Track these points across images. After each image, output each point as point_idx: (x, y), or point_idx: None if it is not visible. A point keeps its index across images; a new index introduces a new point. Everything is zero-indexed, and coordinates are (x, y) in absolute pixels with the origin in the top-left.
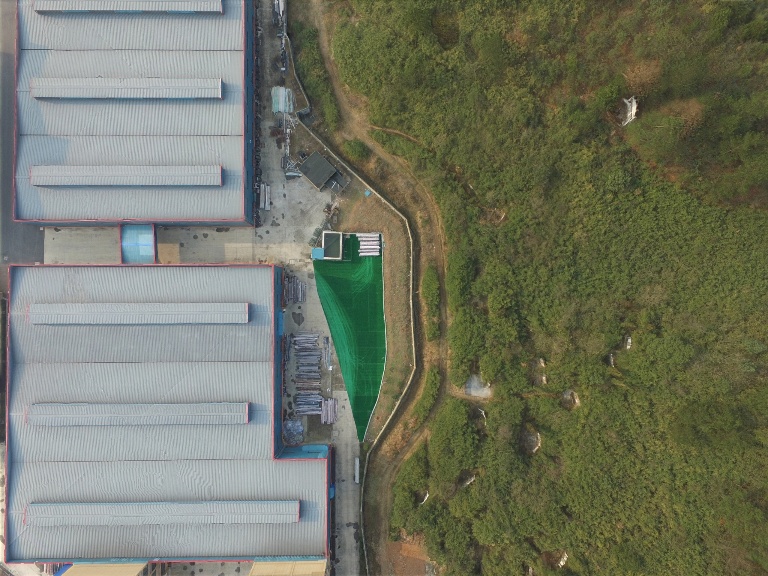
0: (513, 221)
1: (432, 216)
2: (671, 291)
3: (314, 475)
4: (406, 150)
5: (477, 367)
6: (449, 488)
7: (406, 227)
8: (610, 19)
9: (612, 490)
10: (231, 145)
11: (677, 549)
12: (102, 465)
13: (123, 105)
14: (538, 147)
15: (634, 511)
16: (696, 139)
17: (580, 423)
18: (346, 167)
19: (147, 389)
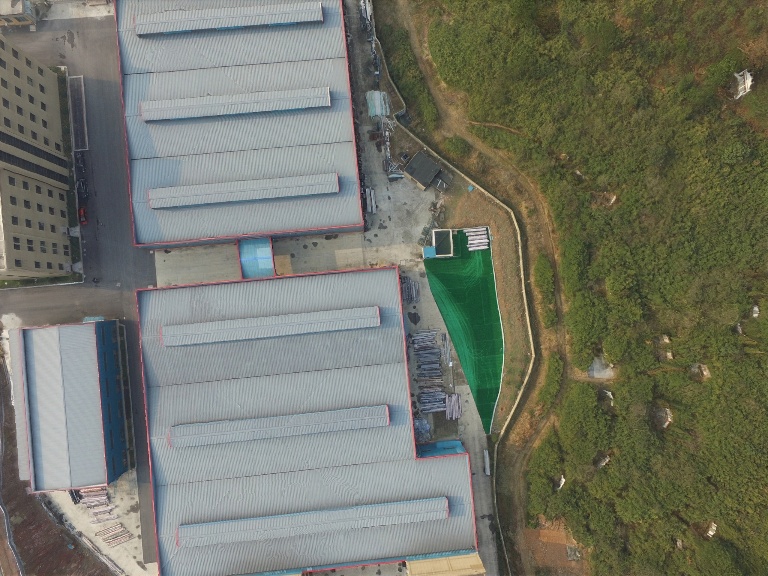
0: (628, 202)
1: (537, 205)
2: None
3: (456, 470)
4: (510, 142)
5: (598, 349)
6: (588, 470)
7: (511, 218)
8: None
9: (755, 456)
10: (342, 152)
11: None
12: (246, 480)
13: (232, 121)
14: (649, 128)
15: None
16: None
17: (714, 394)
18: (448, 164)
19: (284, 401)
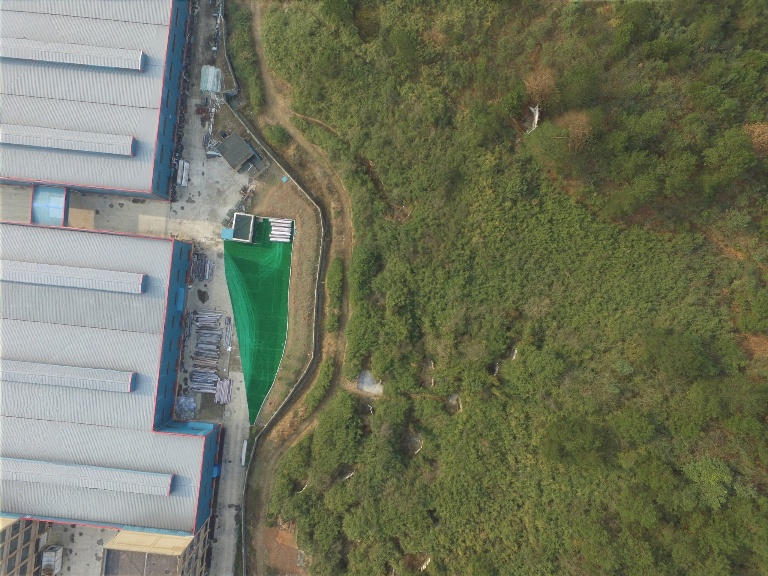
0: (415, 220)
1: (345, 208)
2: (559, 305)
3: (192, 451)
4: (323, 140)
5: None
6: (325, 480)
7: (319, 217)
8: (522, 25)
9: (480, 499)
10: (147, 117)
11: (531, 565)
12: None
13: (46, 68)
14: (445, 148)
15: (499, 523)
16: (592, 153)
17: (458, 429)
18: (266, 151)
19: (38, 348)
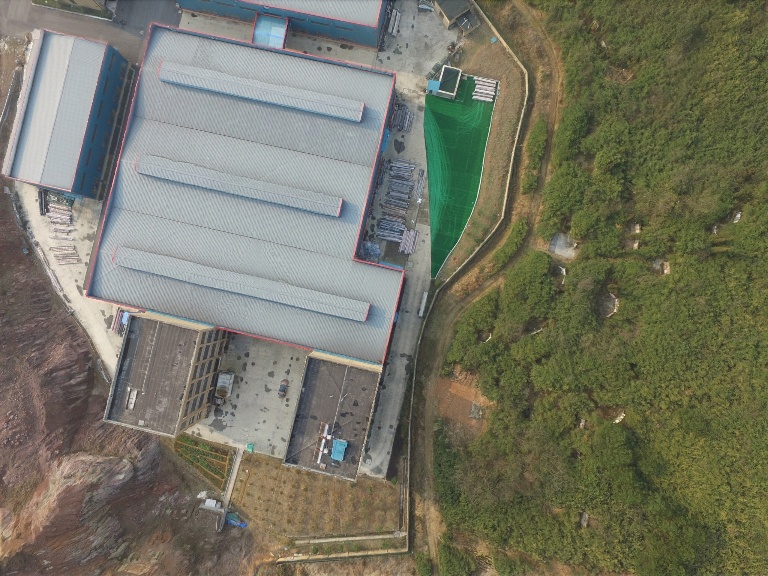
0: (642, 78)
1: (554, 73)
2: None
3: (388, 284)
4: None
5: (567, 226)
6: (516, 329)
7: (524, 80)
8: None
9: (687, 358)
10: None
11: (749, 418)
12: (192, 228)
13: None
14: (687, 5)
15: (707, 381)
16: None
17: (667, 288)
18: (479, 10)
19: (250, 166)
